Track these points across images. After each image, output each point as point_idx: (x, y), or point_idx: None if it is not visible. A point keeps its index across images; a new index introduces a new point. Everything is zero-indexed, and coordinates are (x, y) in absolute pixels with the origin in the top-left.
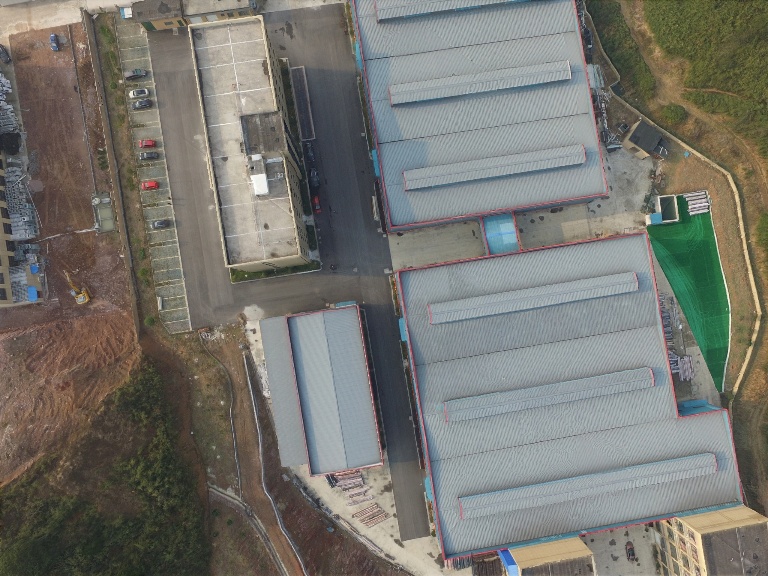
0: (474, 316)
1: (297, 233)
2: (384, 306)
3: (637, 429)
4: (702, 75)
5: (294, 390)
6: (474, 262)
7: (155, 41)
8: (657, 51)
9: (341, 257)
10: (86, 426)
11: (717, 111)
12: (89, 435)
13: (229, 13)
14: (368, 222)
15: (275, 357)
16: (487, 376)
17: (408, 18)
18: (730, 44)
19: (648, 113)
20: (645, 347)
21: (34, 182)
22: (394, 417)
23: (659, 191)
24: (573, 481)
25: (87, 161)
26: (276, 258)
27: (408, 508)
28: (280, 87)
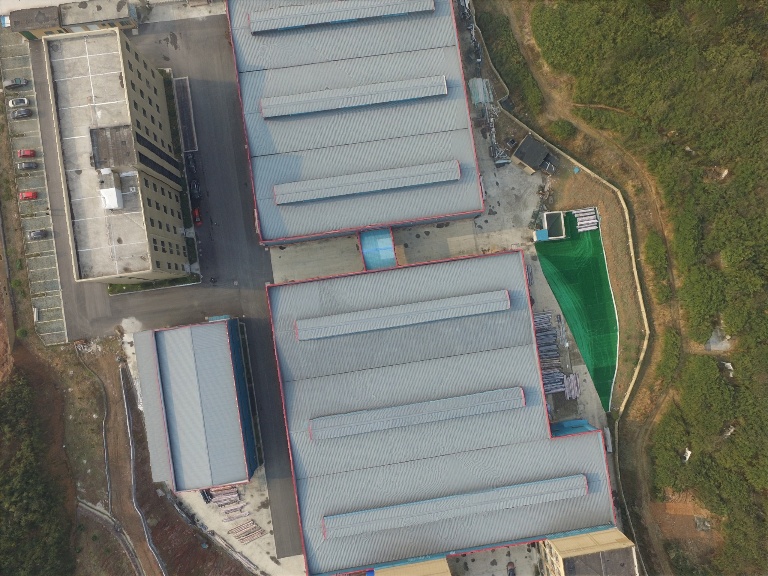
0: (341, 333)
1: (149, 248)
2: (265, 320)
3: (510, 449)
4: (587, 91)
5: None
6: (346, 278)
7: (37, 50)
8: (546, 66)
9: (222, 270)
10: None
11: (605, 127)
12: None
13: (110, 23)
14: (250, 235)
15: (148, 371)
16: (357, 393)
17: (283, 31)
18: (612, 60)
19: (538, 128)
20: (519, 366)
21: None
22: (272, 432)
23: (548, 207)
24: (441, 501)
25: None
26: (127, 273)
27: (285, 525)
28: (154, 99)
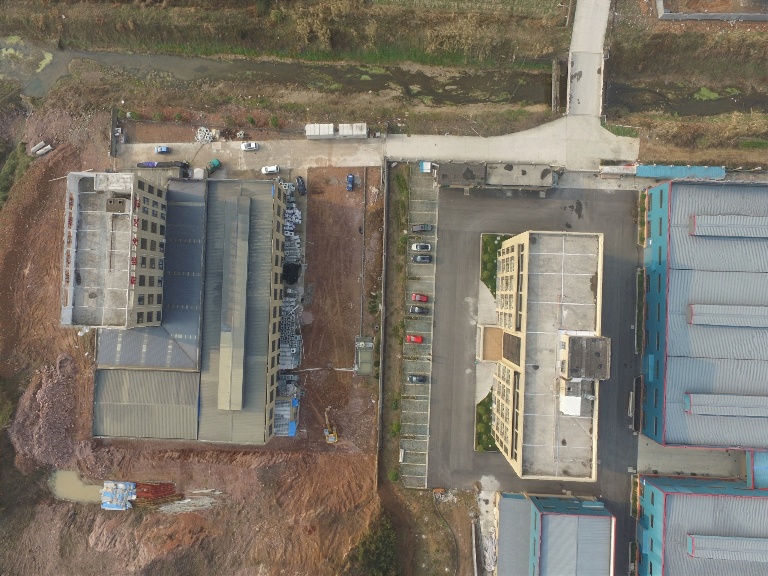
0: (738, 559)
1: None
2: (621, 504)
3: None
4: None
5: (522, 575)
6: (742, 498)
7: (445, 197)
8: None
9: None
10: None
11: None
12: None
13: None
14: (621, 416)
15: (509, 538)
16: None
17: (723, 236)
18: None
19: None
20: None
21: (306, 314)
22: None
23: None
24: None
25: (358, 302)
26: (571, 479)
27: None
28: None
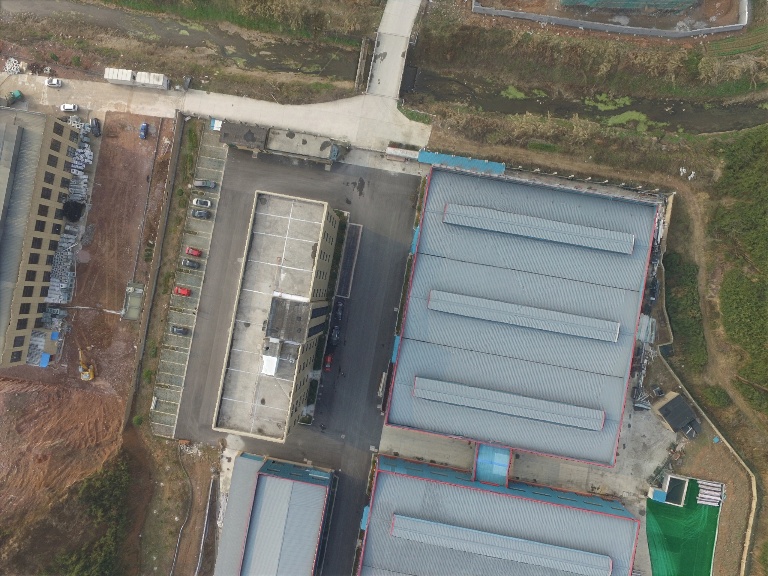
0: (435, 544)
1: (288, 421)
2: (358, 481)
3: None
4: (759, 375)
5: None
6: (455, 487)
7: (233, 158)
8: (721, 329)
9: (334, 419)
10: (45, 510)
11: (763, 412)
12: (45, 520)
13: None
14: (371, 395)
15: (238, 496)
16: None
17: (474, 228)
18: None
19: (690, 384)
20: None
21: (83, 253)
22: None
23: (673, 467)
24: None
25: (135, 248)
26: (261, 437)
27: None
28: (329, 251)
